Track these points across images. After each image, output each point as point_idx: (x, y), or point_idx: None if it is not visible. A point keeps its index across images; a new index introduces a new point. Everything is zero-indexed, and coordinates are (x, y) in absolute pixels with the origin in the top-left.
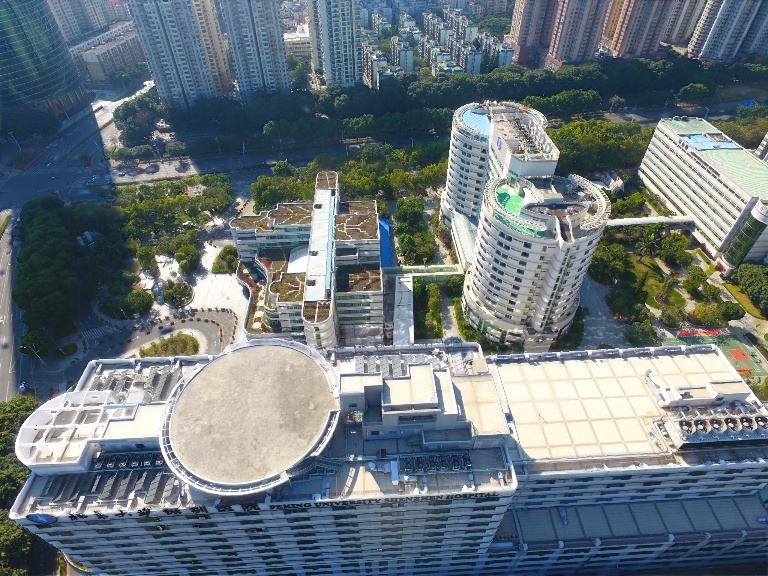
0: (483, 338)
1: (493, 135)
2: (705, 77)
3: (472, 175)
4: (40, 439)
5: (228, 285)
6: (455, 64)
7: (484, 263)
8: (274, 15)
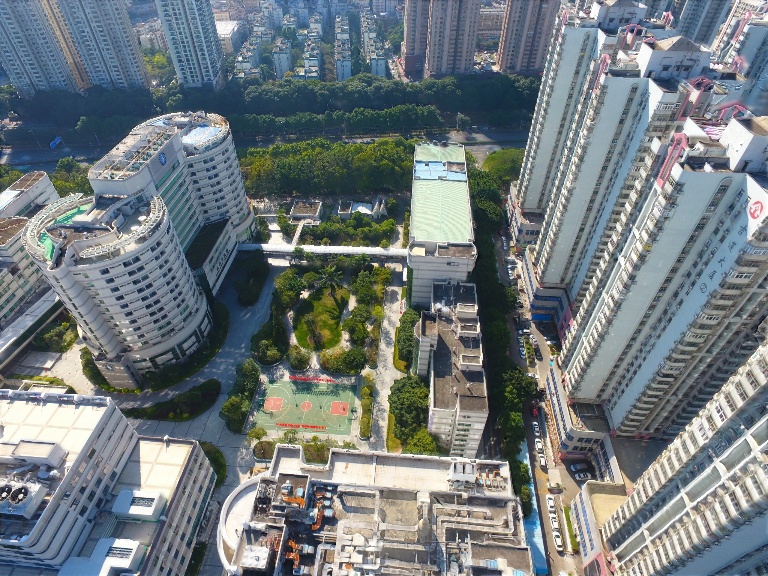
0: (89, 358)
1: None
2: None
3: None
4: None
5: None
6: (314, 70)
7: None
8: (112, 12)
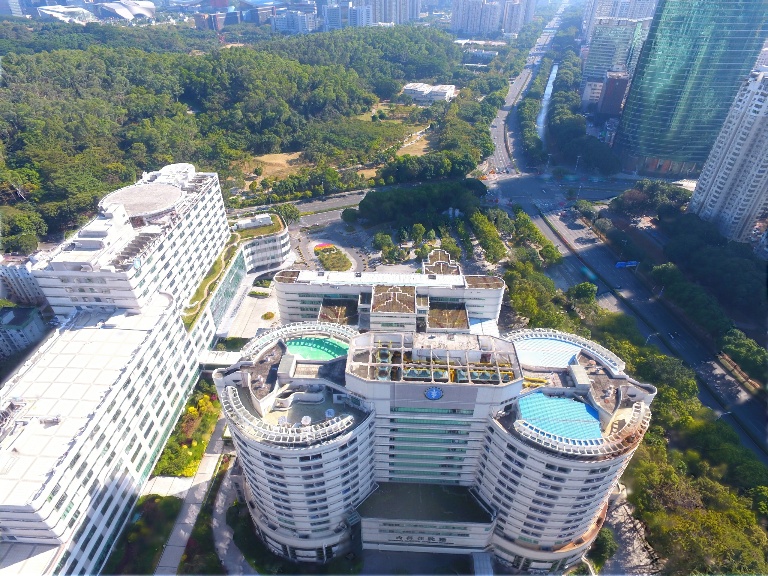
0: None
1: None
2: None
3: None
4: (174, 167)
5: None
6: None
7: None
8: None
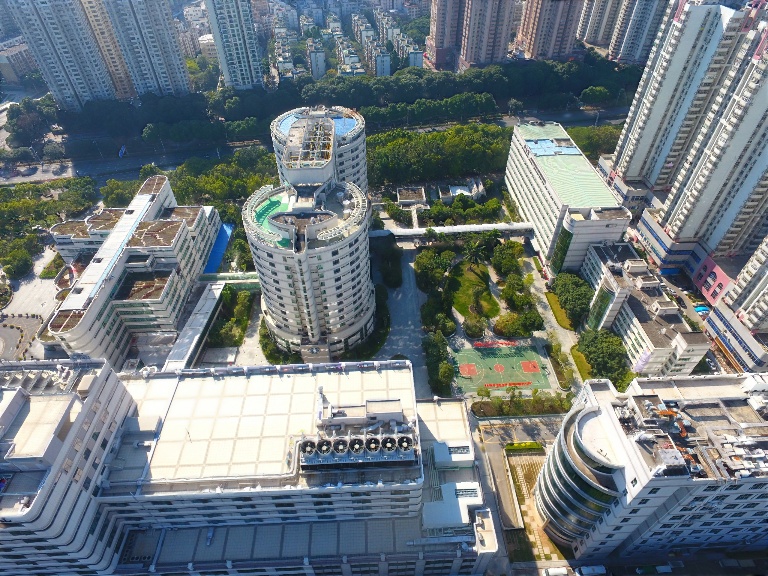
0: (274, 347)
1: None
2: (612, 80)
3: None
4: None
5: (49, 290)
6: (359, 66)
7: None
8: (162, 17)
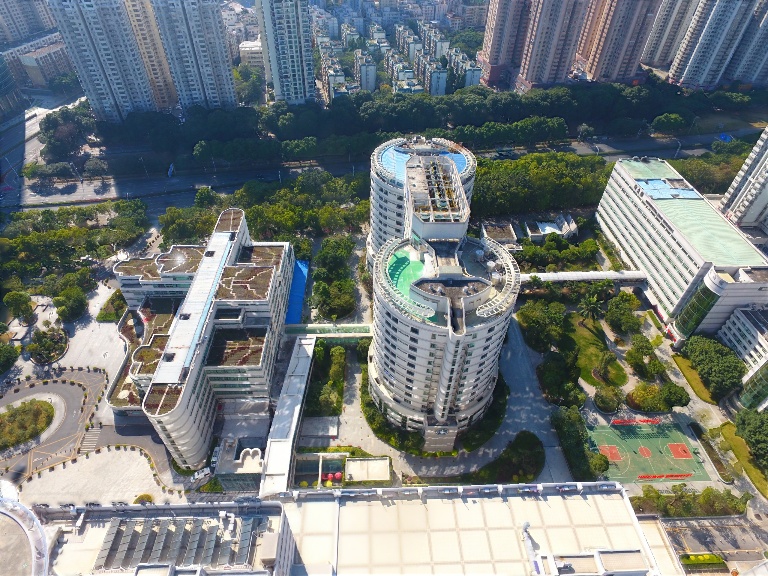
0: (383, 420)
1: (406, 182)
2: (683, 106)
3: (390, 222)
4: None
5: (110, 337)
6: (416, 83)
7: (378, 339)
8: (214, 25)
